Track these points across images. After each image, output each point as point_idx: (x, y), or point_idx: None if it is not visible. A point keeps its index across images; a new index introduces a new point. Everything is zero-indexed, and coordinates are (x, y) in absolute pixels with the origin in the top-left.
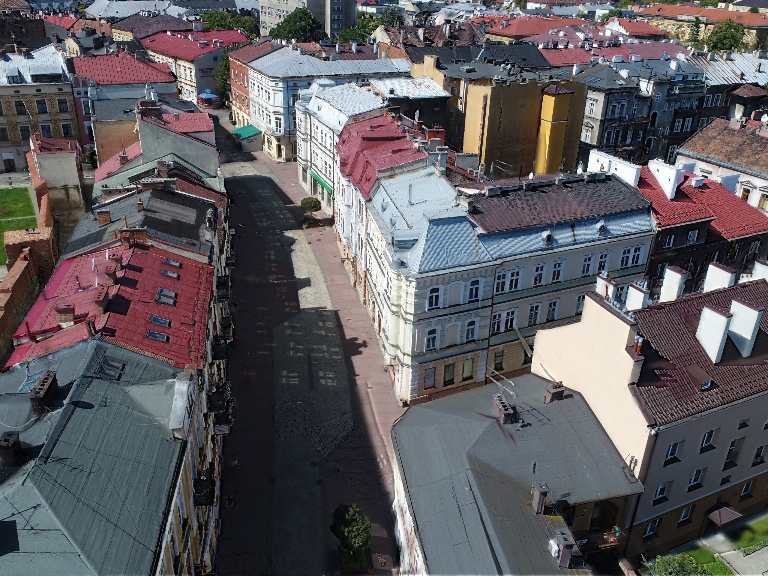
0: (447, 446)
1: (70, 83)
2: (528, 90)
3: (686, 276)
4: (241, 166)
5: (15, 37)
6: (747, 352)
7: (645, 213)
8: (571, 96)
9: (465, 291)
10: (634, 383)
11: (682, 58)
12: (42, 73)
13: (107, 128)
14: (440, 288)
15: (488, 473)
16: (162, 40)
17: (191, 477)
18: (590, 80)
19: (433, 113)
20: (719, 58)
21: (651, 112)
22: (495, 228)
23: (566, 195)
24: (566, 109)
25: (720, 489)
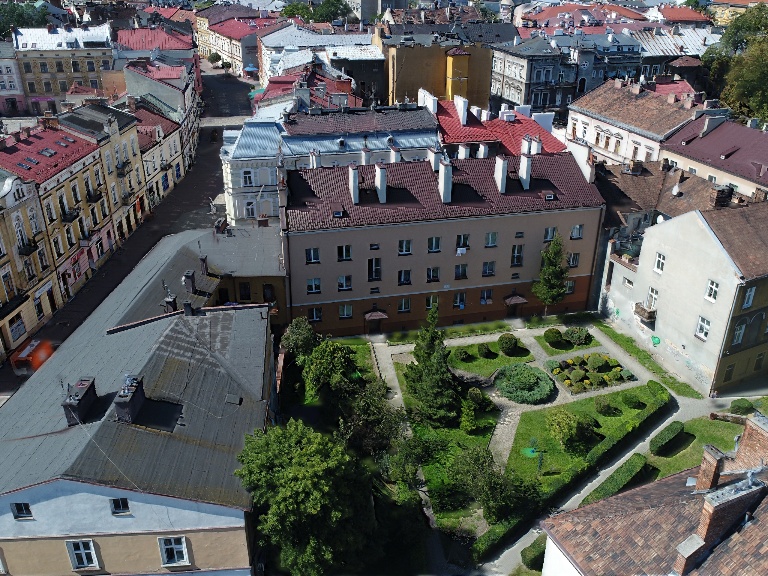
0: (178, 243)
1: (111, 49)
2: (432, 52)
3: (370, 154)
4: (242, 119)
5: (101, 19)
6: (382, 199)
7: (433, 133)
8: (469, 57)
9: (272, 176)
10: (284, 206)
11: (626, 32)
12: (91, 41)
13: (111, 76)
14: (251, 171)
15: (189, 254)
16: (229, 25)
17: (15, 235)
18: (522, 49)
19: (372, 73)
20: (667, 33)
21: (579, 78)
22: (297, 133)
23: (374, 117)
24: (465, 68)
25: (372, 297)
